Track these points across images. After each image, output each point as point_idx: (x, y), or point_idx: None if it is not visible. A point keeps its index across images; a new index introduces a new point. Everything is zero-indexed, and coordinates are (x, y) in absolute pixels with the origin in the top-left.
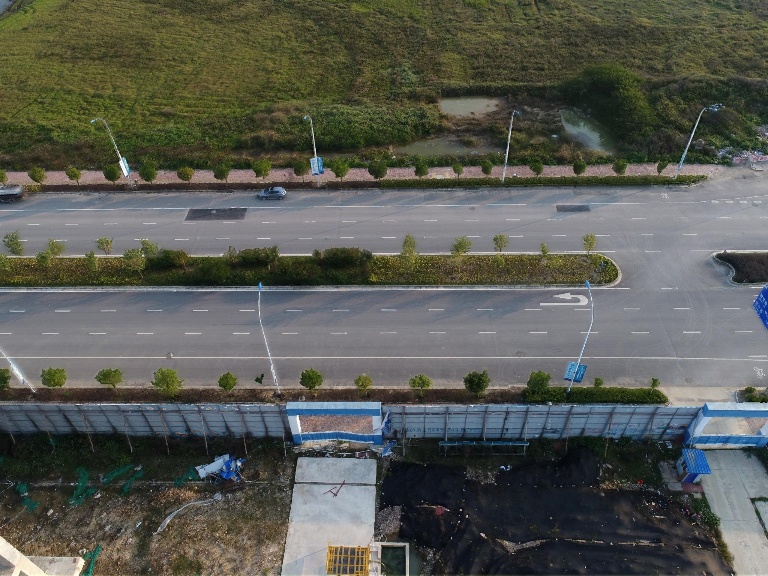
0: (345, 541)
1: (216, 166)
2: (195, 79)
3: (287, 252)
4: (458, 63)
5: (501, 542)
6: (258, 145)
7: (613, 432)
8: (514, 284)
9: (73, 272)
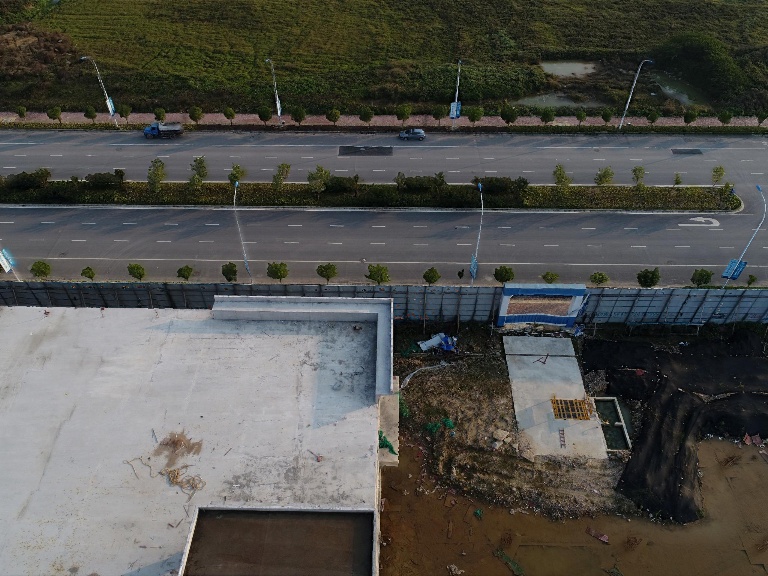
0: (563, 396)
1: (362, 109)
2: (306, 39)
3: None
4: (550, 31)
5: (697, 394)
6: (384, 96)
7: None
8: (652, 209)
9: (253, 194)
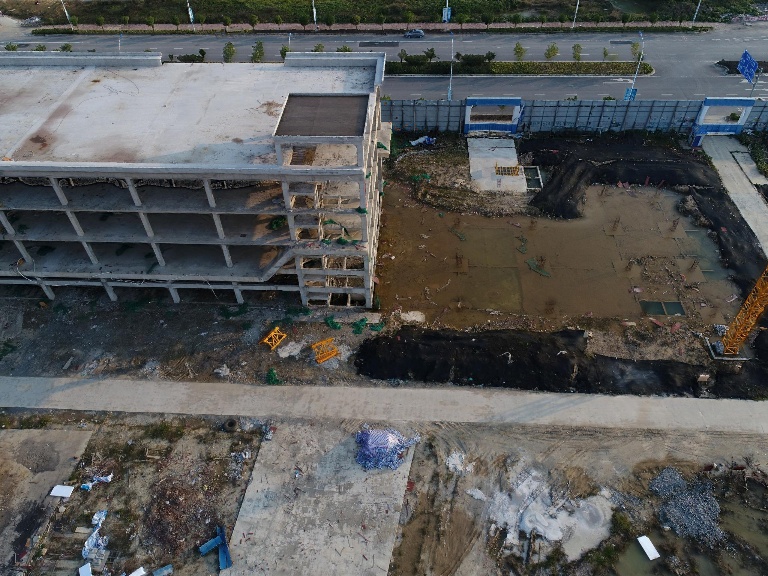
0: (503, 165)
1: (377, 15)
2: None
3: (433, 61)
4: None
5: (591, 161)
6: (395, 12)
7: (652, 126)
8: (586, 74)
9: None
